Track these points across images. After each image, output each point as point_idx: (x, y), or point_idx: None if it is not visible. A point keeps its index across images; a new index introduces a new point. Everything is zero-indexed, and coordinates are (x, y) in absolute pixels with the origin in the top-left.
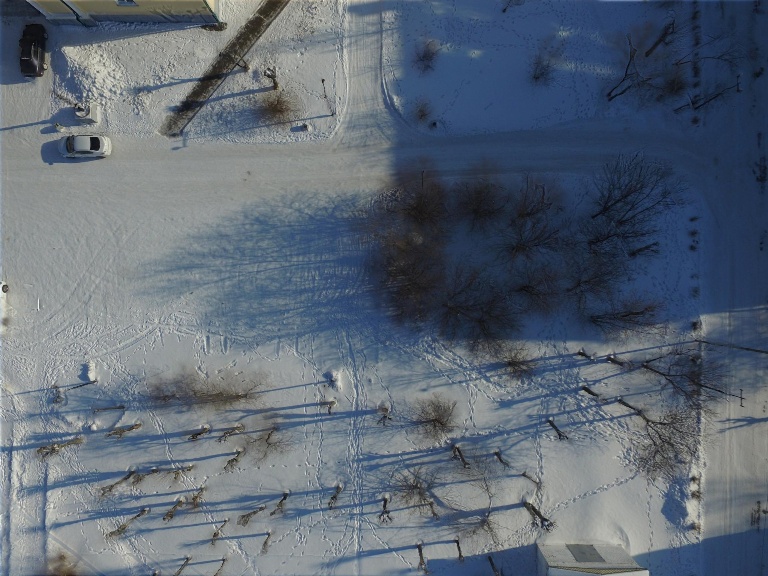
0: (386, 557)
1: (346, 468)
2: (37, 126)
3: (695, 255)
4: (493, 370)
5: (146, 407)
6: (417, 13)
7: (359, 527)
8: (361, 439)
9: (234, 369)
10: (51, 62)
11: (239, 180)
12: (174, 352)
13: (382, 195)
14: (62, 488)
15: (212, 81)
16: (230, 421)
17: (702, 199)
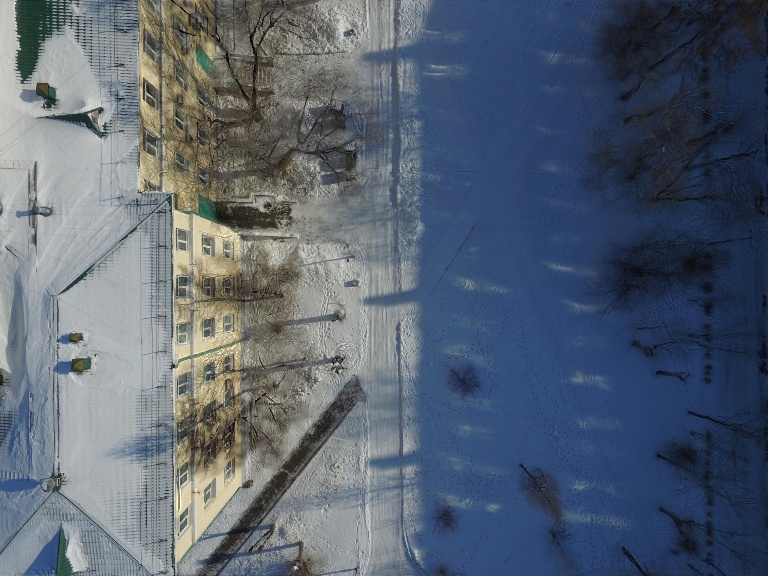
0: None
1: None
2: None
3: None
4: None
5: None
6: (436, 469)
7: None
8: None
9: None
10: None
11: None
12: None
13: None
14: None
15: (239, 535)
16: None
17: None
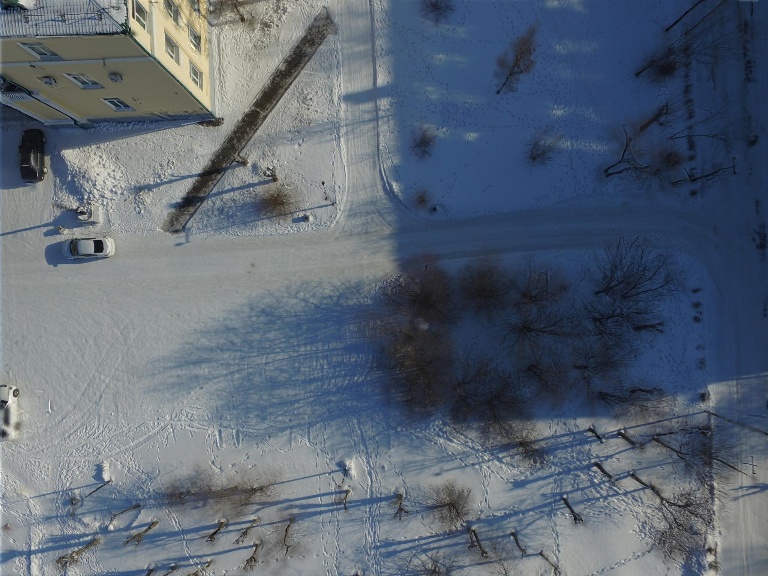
0: None
1: (364, 556)
2: (40, 229)
3: (699, 326)
4: (505, 451)
5: (162, 504)
6: (412, 99)
7: None
8: (377, 526)
9: (247, 462)
10: (51, 165)
11: (243, 273)
12: (187, 448)
13: (386, 281)
14: None
15: (212, 176)
16: (246, 514)
17: (703, 269)
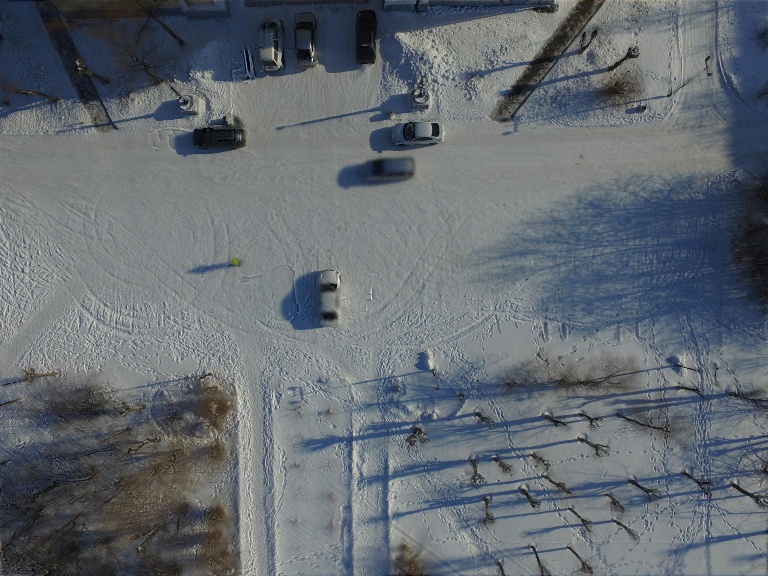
0: (736, 543)
1: (693, 454)
2: (366, 114)
3: None
4: None
5: (486, 395)
6: None
7: (707, 513)
8: (708, 424)
9: (575, 355)
10: (380, 49)
11: (572, 164)
12: (513, 339)
13: (719, 176)
14: (402, 478)
15: (543, 64)
16: (572, 408)
17: None
